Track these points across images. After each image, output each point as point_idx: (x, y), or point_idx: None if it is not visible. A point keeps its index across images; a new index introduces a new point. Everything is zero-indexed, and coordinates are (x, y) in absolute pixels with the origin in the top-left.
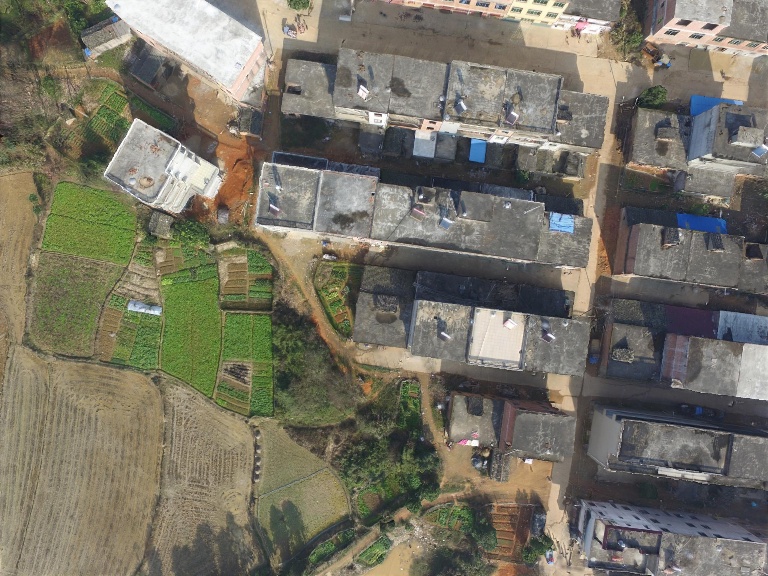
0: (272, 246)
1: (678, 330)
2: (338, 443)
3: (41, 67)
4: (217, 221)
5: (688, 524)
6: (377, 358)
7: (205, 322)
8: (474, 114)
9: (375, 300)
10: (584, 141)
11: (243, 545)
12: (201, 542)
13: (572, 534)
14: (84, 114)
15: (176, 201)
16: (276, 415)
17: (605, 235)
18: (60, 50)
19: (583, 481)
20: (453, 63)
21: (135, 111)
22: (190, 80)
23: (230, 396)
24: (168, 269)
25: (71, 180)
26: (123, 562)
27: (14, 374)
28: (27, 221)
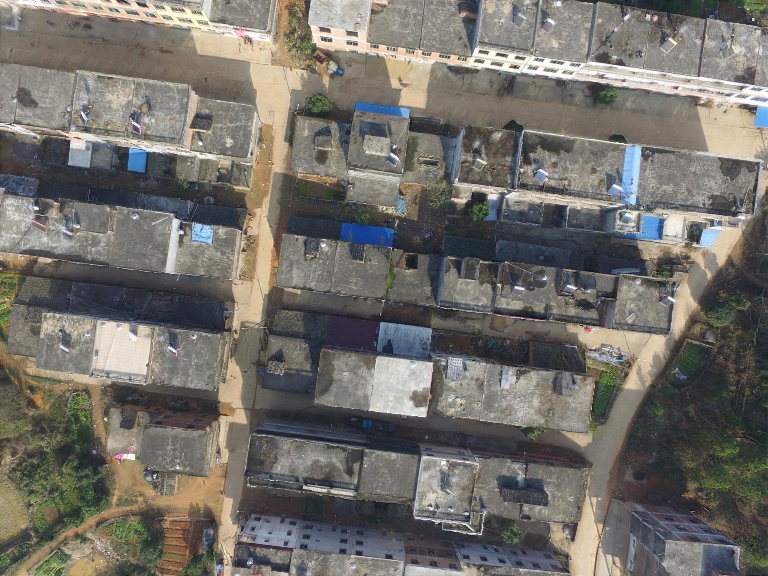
0: None
1: (337, 342)
2: (14, 456)
3: None
4: None
5: (342, 540)
6: (48, 370)
7: None
8: (101, 124)
9: None
10: (229, 150)
11: None
12: None
13: None
14: None
15: None
16: None
17: (278, 245)
18: None
19: (256, 495)
20: (79, 73)
21: None
22: None
23: None
24: None
25: None
26: None
27: None
28: None
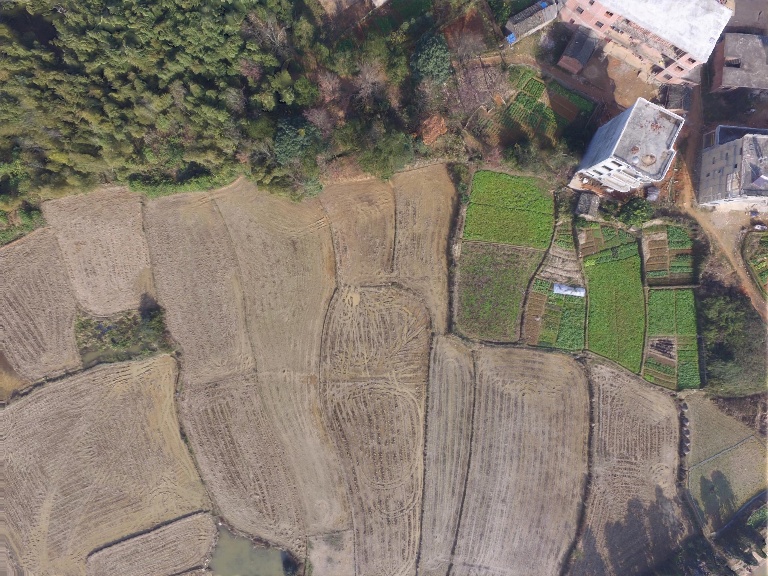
0: (701, 220)
1: None
2: (766, 410)
3: (455, 58)
4: None
5: None
6: None
7: (629, 300)
8: None
9: None
10: None
11: (673, 517)
12: (632, 517)
13: None
14: (504, 102)
15: None
16: (709, 387)
17: None
18: (473, 40)
19: None
20: None
21: (553, 95)
22: (610, 61)
23: (657, 371)
24: (589, 250)
25: (488, 168)
26: (555, 542)
27: (439, 364)
28: (442, 212)
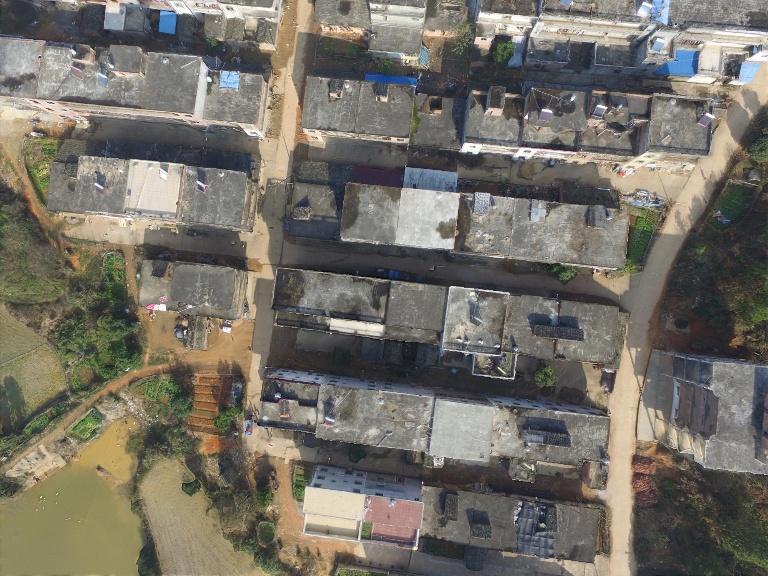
0: None
1: None
2: (53, 318)
3: None
4: None
5: (370, 385)
6: (84, 232)
7: None
8: None
9: None
10: (254, 1)
11: None
12: None
13: None
14: None
15: None
16: None
17: (302, 102)
18: None
19: (283, 351)
20: None
21: None
22: None
23: None
24: None
25: None
26: None
27: None
28: None
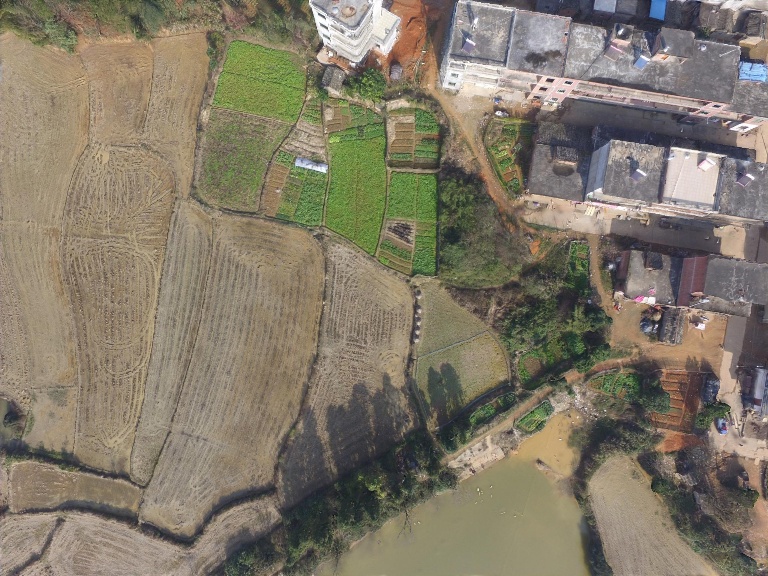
0: (443, 103)
1: None
2: (501, 305)
3: None
4: (389, 78)
5: None
6: (545, 218)
7: (370, 180)
8: None
9: (553, 152)
10: None
11: (399, 408)
12: (357, 403)
13: (746, 403)
14: None
15: (362, 45)
16: (440, 273)
17: None
18: None
19: (757, 350)
20: None
21: None
22: None
23: (393, 255)
24: (336, 127)
25: (244, 39)
26: (277, 420)
27: (178, 228)
28: (198, 80)
